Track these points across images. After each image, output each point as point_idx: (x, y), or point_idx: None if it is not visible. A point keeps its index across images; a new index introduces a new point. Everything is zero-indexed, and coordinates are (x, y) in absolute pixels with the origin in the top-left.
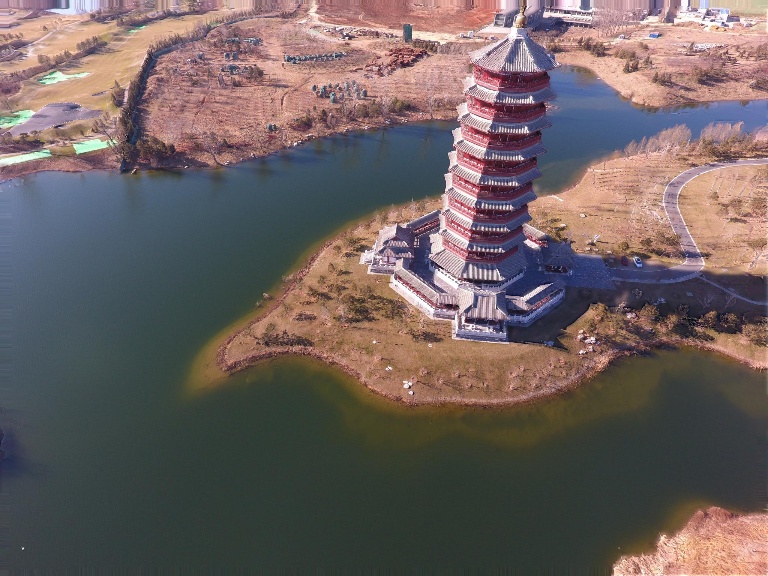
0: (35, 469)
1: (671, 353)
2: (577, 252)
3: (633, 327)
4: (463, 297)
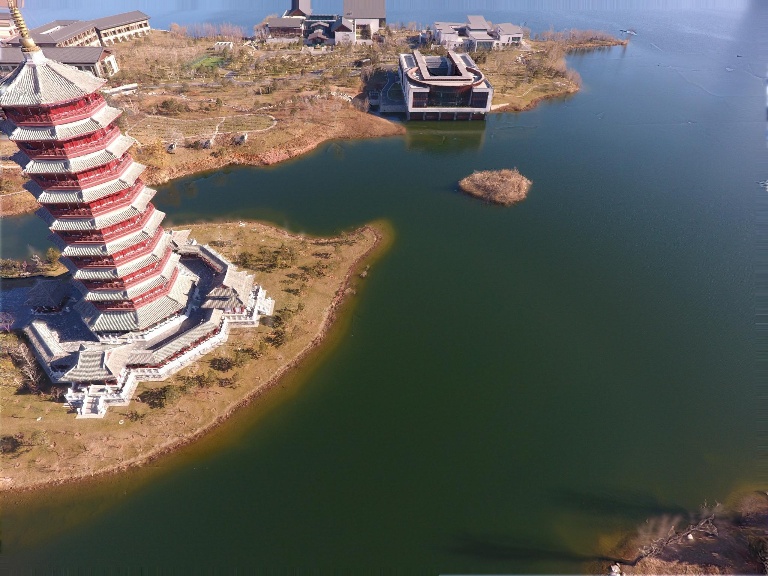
0: (440, 189)
1: (21, 264)
2: (3, 330)
3: (34, 270)
4: (181, 241)
